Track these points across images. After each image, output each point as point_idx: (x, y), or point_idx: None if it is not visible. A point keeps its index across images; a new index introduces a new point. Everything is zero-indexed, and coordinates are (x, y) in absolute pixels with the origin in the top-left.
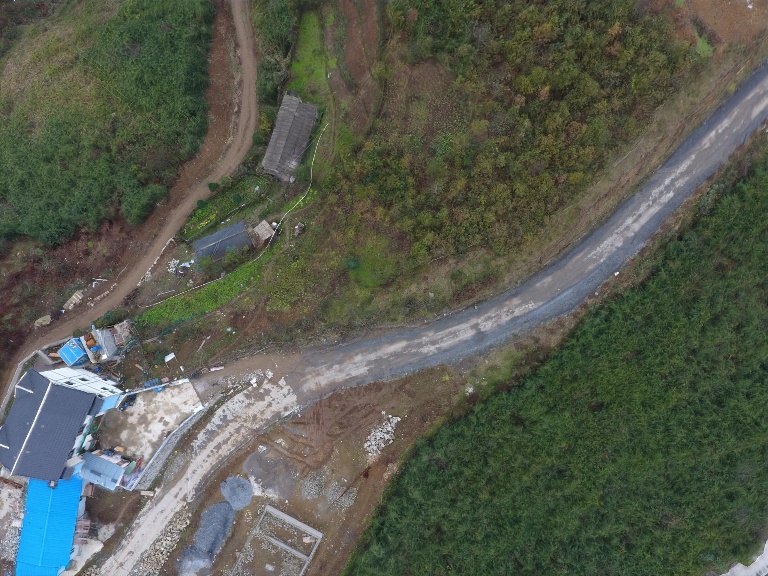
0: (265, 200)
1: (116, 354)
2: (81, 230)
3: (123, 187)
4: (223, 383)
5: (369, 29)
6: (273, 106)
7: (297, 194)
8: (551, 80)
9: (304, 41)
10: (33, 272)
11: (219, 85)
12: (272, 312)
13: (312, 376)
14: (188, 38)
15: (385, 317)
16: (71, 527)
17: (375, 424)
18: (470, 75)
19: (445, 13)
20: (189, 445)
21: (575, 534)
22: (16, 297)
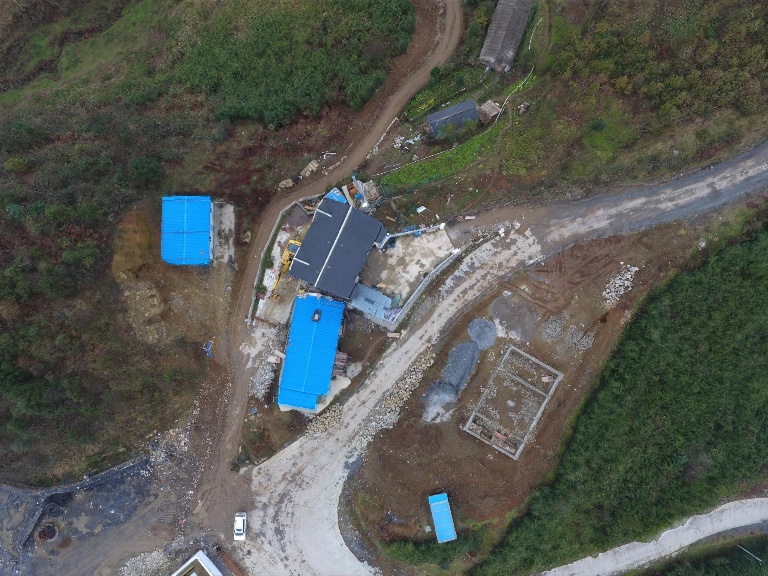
0: (482, 86)
1: (370, 206)
2: None
3: (346, 73)
4: (474, 232)
5: None
6: None
7: (516, 79)
8: None
9: None
10: (262, 147)
11: None
12: (509, 175)
13: (556, 228)
14: None
15: (628, 174)
16: (331, 358)
17: (614, 273)
18: None
19: None
20: (437, 290)
21: (761, 408)
22: (256, 164)
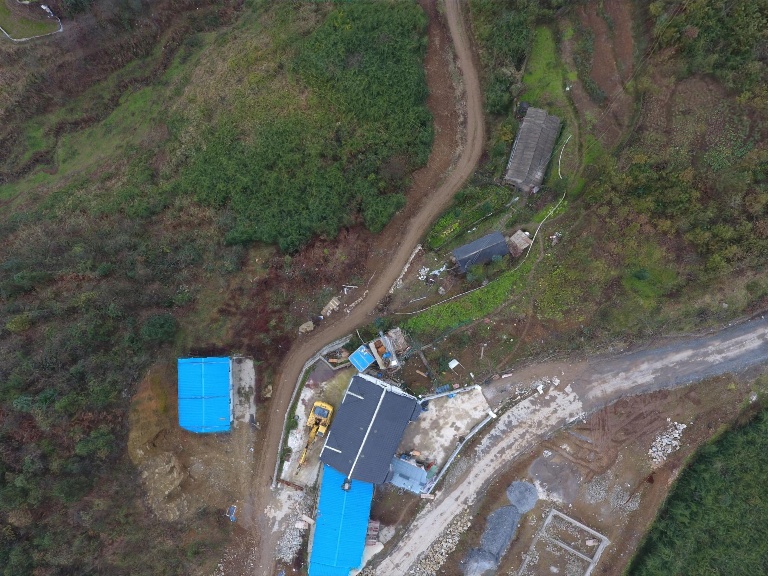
0: (509, 210)
1: None
2: (319, 237)
3: (364, 196)
4: (511, 390)
5: (624, 44)
6: (501, 117)
7: (546, 204)
8: None
9: (536, 54)
10: (278, 278)
11: (439, 95)
12: (545, 320)
13: (598, 383)
14: (411, 49)
15: (674, 326)
16: (363, 529)
17: (660, 431)
18: (760, 91)
19: (728, 30)
20: (473, 450)
21: None
22: (274, 303)
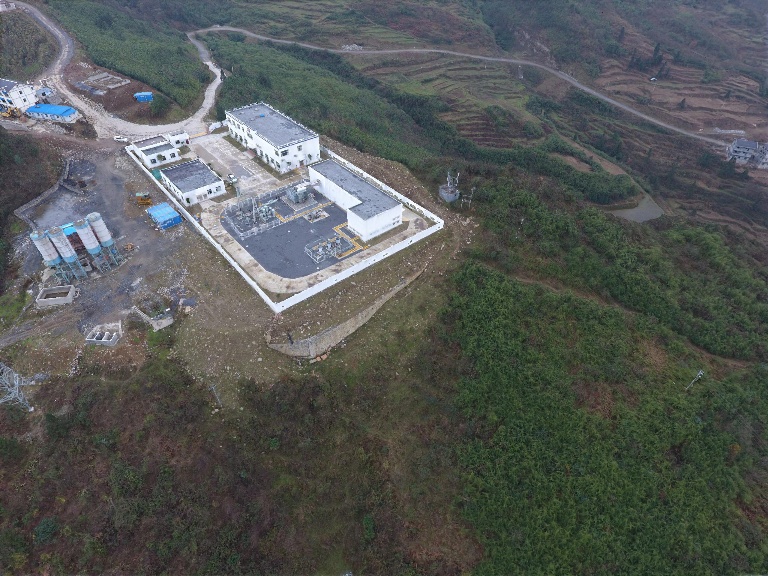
0: None
1: None
2: None
3: None
4: None
5: None
6: None
7: None
8: (2, 29)
9: None
10: None
11: None
12: None
13: None
14: None
15: (47, 61)
16: None
17: None
18: None
19: None
20: None
21: None
22: None
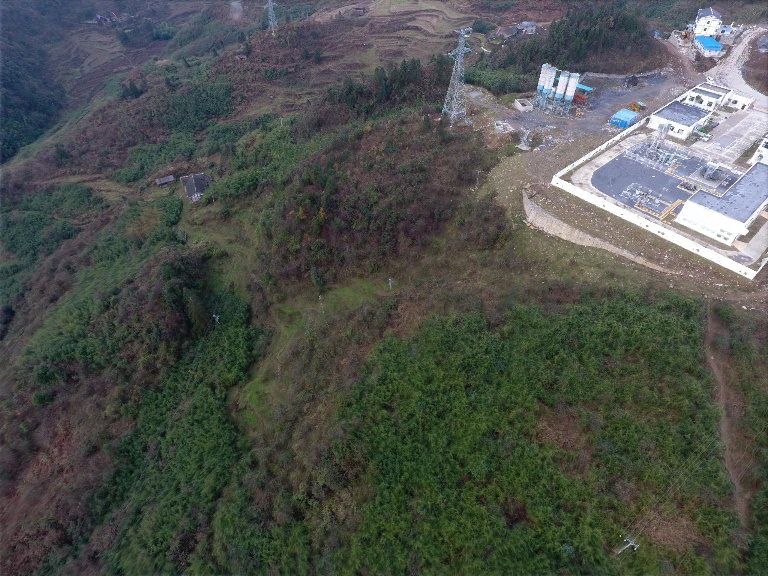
0: None
1: None
2: None
3: None
4: None
5: None
6: None
7: None
8: None
9: None
10: None
11: None
12: None
13: None
14: None
15: None
16: None
17: None
18: None
19: None
20: None
21: None
22: None
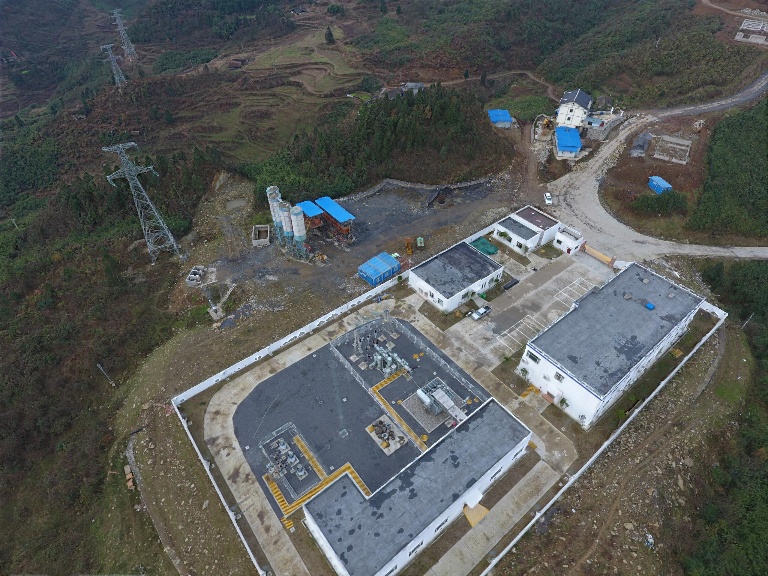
0: None
1: None
2: None
3: None
4: None
5: None
6: None
7: None
8: None
9: (594, 94)
10: None
11: None
12: None
13: None
14: None
15: (682, 102)
16: None
17: None
18: None
19: None
20: (617, 129)
21: None
22: None
